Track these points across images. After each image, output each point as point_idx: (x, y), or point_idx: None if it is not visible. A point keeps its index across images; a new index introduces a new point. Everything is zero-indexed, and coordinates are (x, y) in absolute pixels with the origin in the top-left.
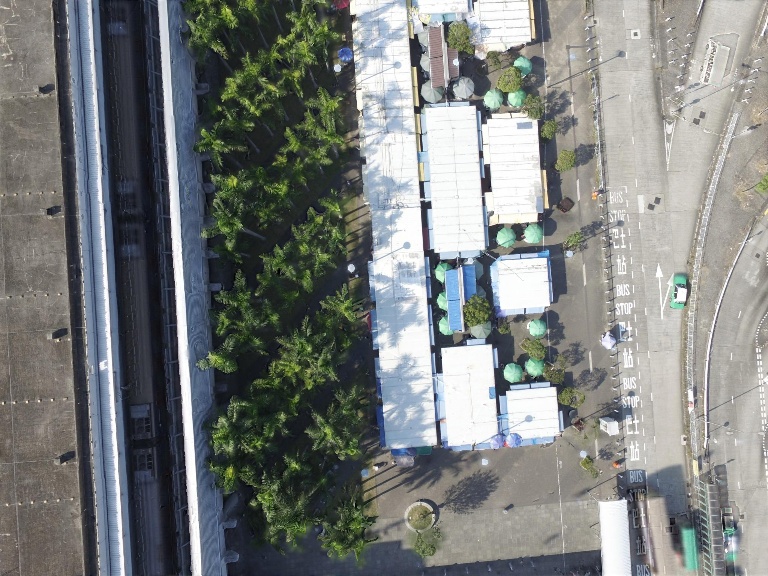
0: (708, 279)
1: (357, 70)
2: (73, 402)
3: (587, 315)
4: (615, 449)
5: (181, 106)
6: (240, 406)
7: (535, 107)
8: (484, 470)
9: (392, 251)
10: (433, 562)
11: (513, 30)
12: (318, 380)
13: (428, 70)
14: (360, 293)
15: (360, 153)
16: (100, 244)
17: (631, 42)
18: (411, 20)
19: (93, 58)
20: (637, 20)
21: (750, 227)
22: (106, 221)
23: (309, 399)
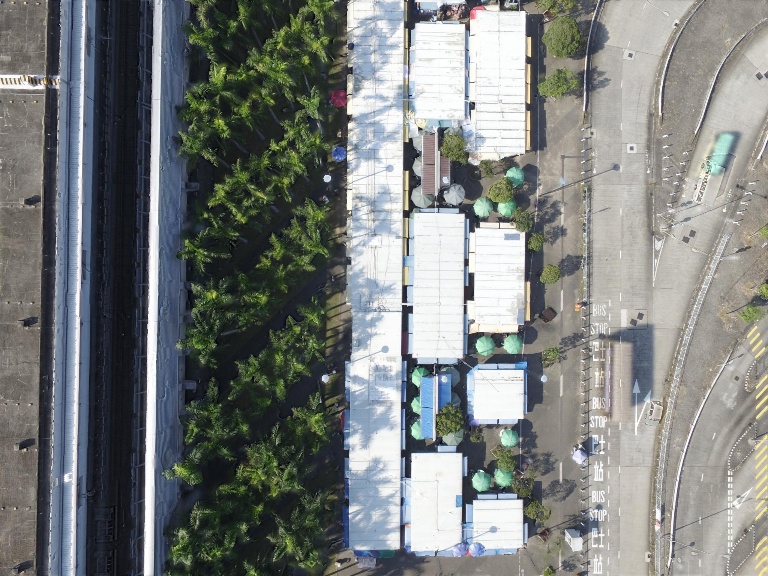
0: (685, 398)
1: (349, 170)
2: (35, 514)
3: (561, 426)
4: (578, 561)
5: (167, 213)
6: (203, 513)
7: (523, 222)
8: (446, 573)
9: (370, 354)
10: None
11: (508, 141)
12: None
13: (420, 175)
14: (336, 388)
15: (346, 253)
16: (74, 357)
17: (626, 156)
18: (407, 124)
19: (81, 172)
20: (634, 134)
21: (731, 350)
22: (83, 330)
23: (274, 505)
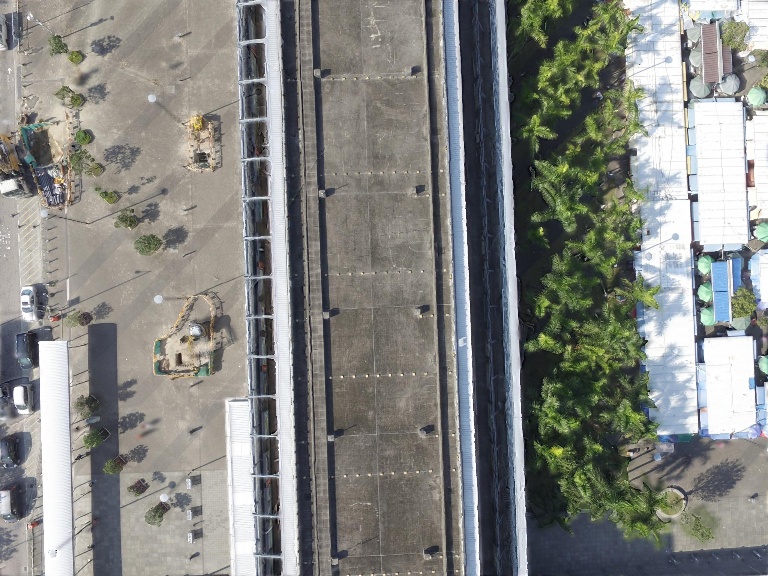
0: None
1: (629, 63)
2: (438, 377)
3: None
4: None
5: None
6: (555, 387)
7: None
8: (731, 459)
9: (661, 242)
10: (681, 547)
11: None
12: (614, 365)
13: (697, 65)
14: (617, 282)
15: (630, 145)
16: (461, 224)
17: None
18: (681, 16)
19: (458, 42)
20: None
21: None
22: None
23: None
